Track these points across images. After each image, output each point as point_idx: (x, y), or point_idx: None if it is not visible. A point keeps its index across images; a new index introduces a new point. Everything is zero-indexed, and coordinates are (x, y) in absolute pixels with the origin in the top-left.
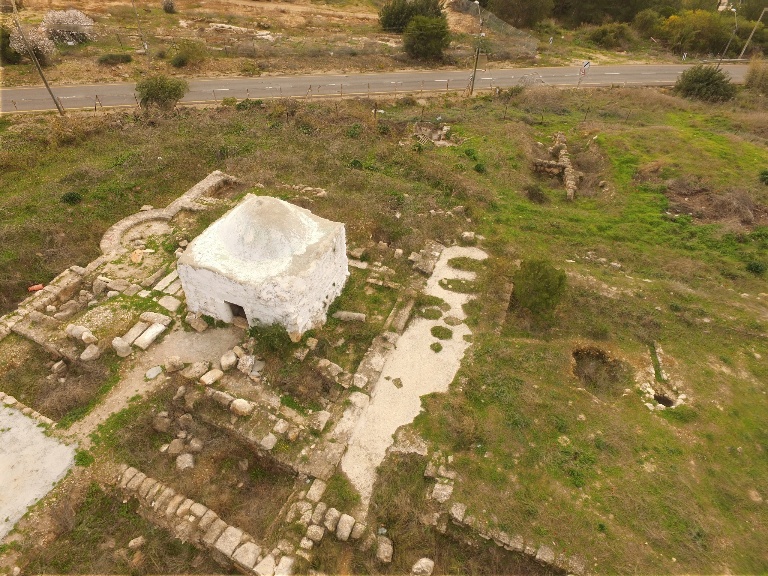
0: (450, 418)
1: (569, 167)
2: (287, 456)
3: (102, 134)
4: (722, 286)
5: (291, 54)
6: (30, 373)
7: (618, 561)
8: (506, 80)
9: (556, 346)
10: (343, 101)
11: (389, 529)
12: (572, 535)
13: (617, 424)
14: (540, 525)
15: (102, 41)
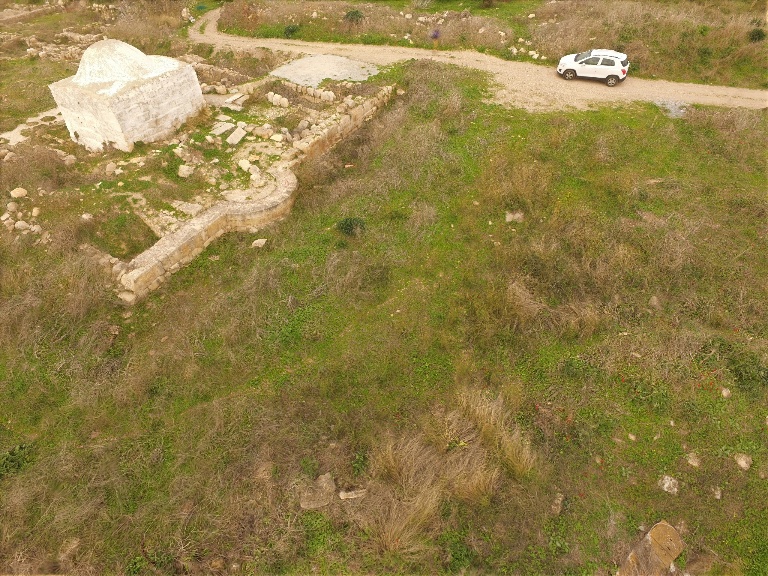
0: None
1: None
2: None
3: None
4: None
5: None
6: None
7: (73, 67)
8: None
9: None
10: None
11: None
12: None
13: None
14: None
15: None
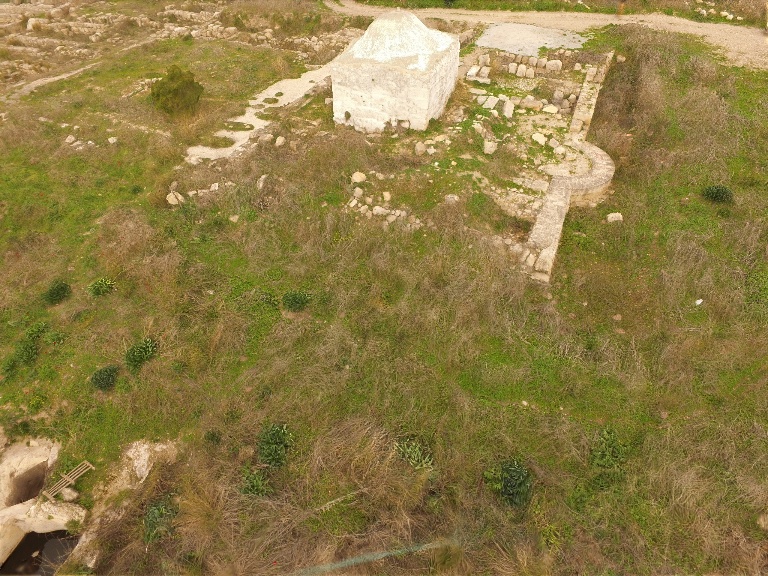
0: None
1: None
2: None
3: None
4: (6, 122)
5: None
6: None
7: None
8: None
9: None
10: None
11: None
12: None
13: (196, 72)
14: None
15: None
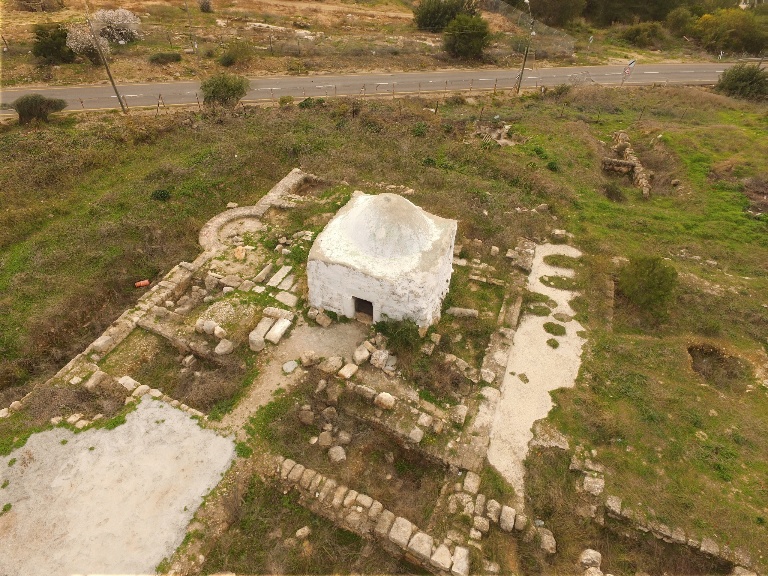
0: (584, 413)
1: (639, 166)
2: (435, 449)
3: (173, 132)
4: None
5: (335, 53)
6: (163, 367)
7: None
8: (549, 79)
9: (670, 343)
10: (400, 100)
11: (546, 521)
12: (733, 528)
13: (749, 420)
14: (698, 518)
15: (149, 40)
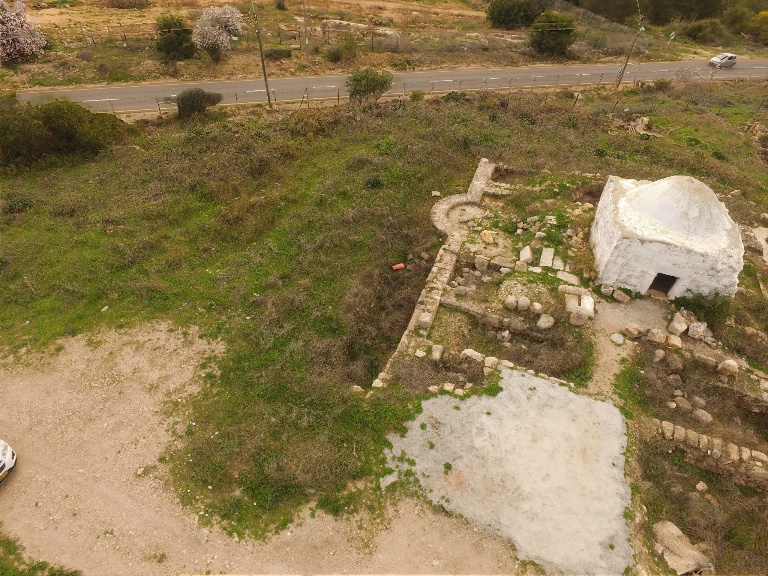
0: None
1: None
2: None
3: (339, 125)
4: None
5: (430, 49)
6: (486, 341)
7: None
8: (638, 74)
9: None
10: (530, 93)
11: None
12: None
13: None
14: None
15: (251, 36)
